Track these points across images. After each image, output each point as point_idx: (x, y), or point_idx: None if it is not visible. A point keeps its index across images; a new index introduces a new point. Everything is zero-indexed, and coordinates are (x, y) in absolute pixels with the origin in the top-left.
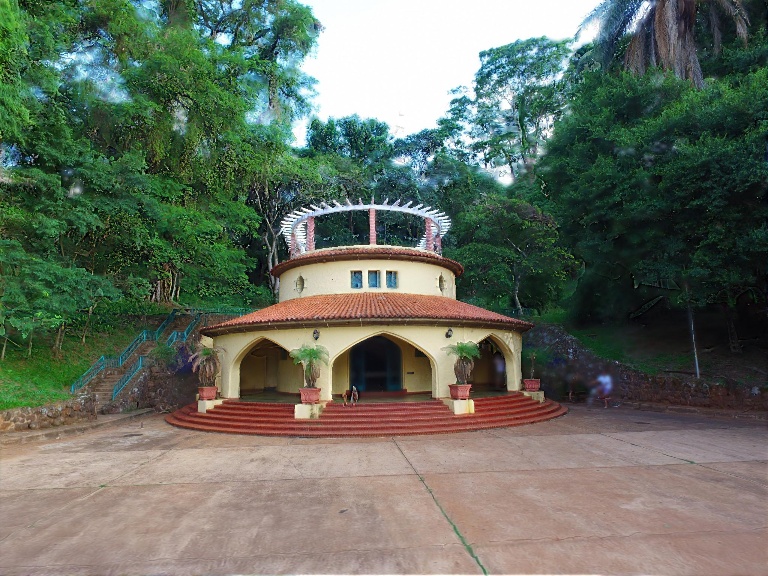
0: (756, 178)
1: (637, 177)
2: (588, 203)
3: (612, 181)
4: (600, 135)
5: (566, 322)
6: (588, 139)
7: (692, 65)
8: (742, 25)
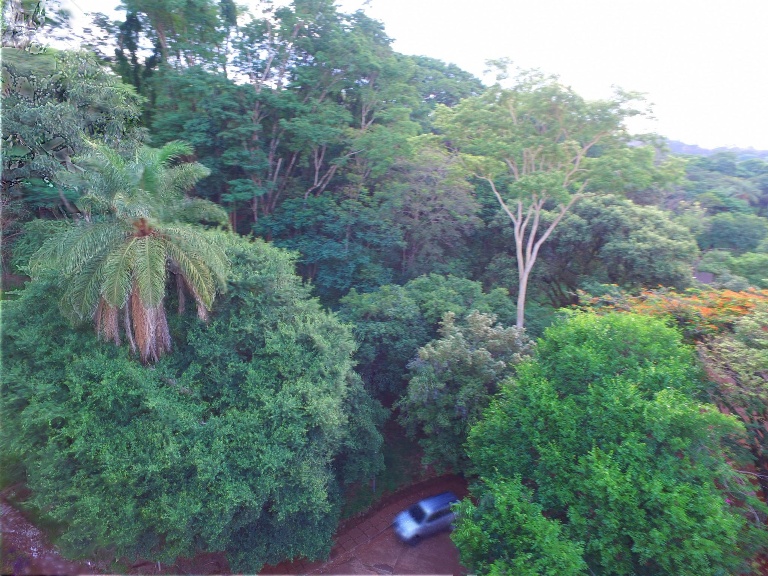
0: (215, 536)
1: (124, 510)
2: (70, 519)
3: (99, 510)
4: (81, 450)
5: (17, 485)
6: (67, 452)
7: (161, 322)
8: (202, 310)
